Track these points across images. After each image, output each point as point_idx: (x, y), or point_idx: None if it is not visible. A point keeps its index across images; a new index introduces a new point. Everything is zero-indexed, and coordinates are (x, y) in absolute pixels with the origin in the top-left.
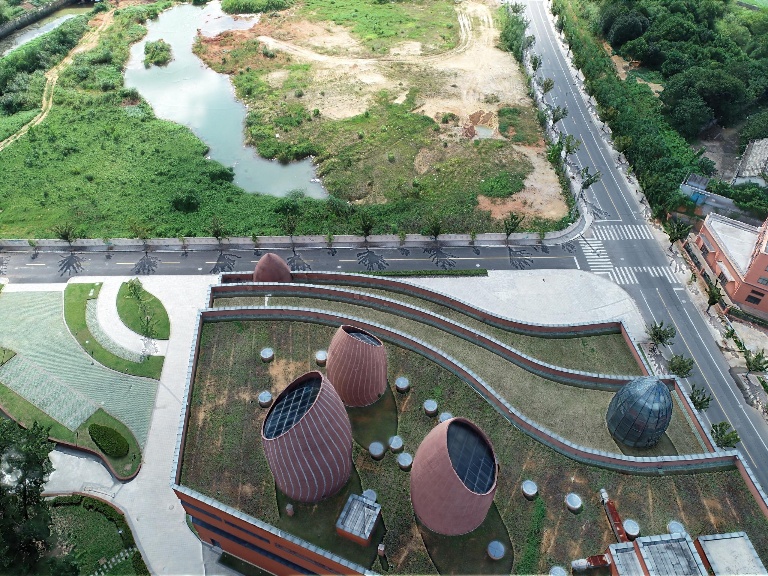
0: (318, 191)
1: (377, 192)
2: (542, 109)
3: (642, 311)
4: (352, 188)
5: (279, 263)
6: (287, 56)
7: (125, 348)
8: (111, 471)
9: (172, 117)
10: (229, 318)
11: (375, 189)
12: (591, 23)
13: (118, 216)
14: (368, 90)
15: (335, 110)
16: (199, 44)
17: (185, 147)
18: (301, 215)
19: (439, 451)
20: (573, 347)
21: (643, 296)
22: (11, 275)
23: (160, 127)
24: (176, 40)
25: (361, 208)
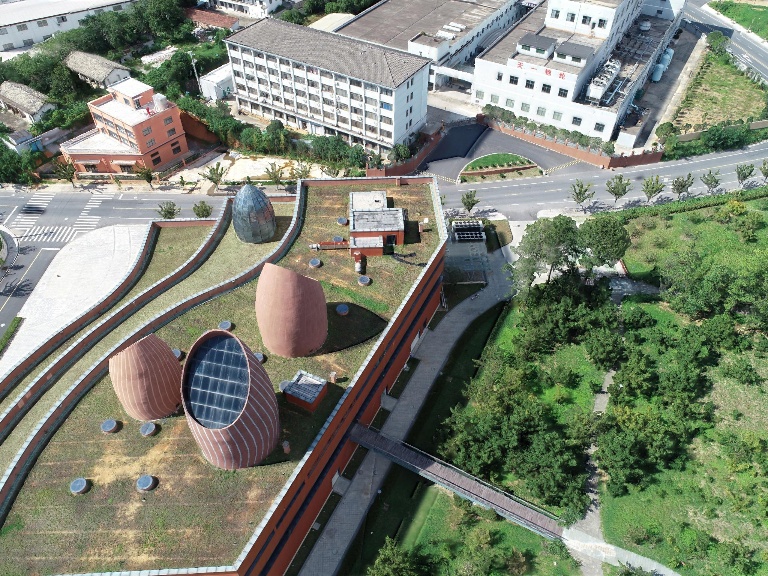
0: None
1: None
2: None
3: (132, 223)
4: None
5: None
6: None
7: None
8: None
9: None
10: None
11: None
12: None
13: None
14: None
15: None
16: None
17: None
18: None
19: (292, 280)
20: (162, 259)
21: (117, 218)
22: None
23: None
24: None
25: None
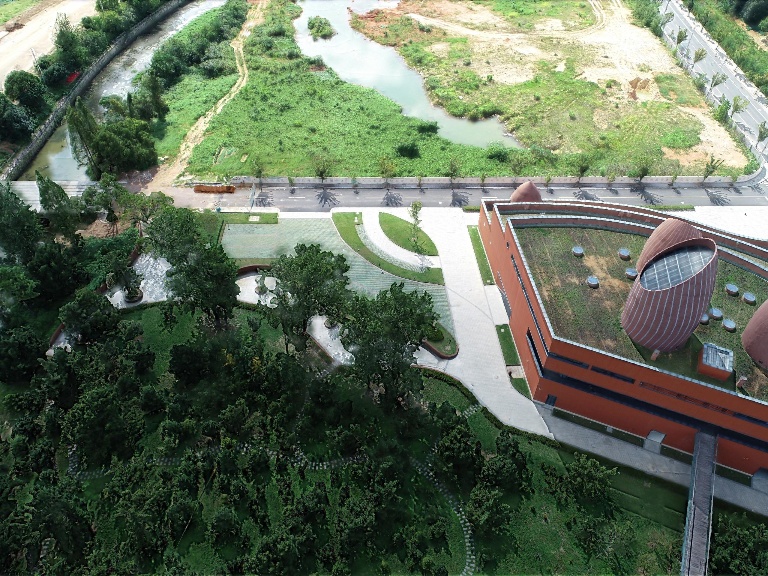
0: (514, 143)
1: (570, 144)
2: (697, 76)
3: None
4: (545, 141)
5: (537, 190)
6: (442, 31)
7: (405, 262)
8: (432, 352)
9: (357, 82)
10: (531, 226)
11: (567, 141)
12: (720, 2)
13: (352, 160)
14: (528, 60)
15: (505, 76)
16: (356, 20)
17: (384, 106)
18: (512, 161)
19: None
20: None
21: None
22: (280, 206)
23: (354, 89)
24: (332, 17)
25: (561, 156)
